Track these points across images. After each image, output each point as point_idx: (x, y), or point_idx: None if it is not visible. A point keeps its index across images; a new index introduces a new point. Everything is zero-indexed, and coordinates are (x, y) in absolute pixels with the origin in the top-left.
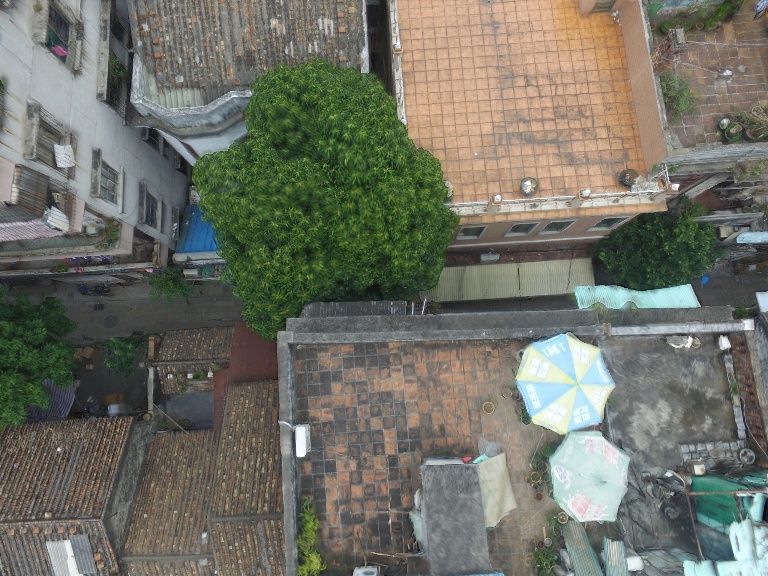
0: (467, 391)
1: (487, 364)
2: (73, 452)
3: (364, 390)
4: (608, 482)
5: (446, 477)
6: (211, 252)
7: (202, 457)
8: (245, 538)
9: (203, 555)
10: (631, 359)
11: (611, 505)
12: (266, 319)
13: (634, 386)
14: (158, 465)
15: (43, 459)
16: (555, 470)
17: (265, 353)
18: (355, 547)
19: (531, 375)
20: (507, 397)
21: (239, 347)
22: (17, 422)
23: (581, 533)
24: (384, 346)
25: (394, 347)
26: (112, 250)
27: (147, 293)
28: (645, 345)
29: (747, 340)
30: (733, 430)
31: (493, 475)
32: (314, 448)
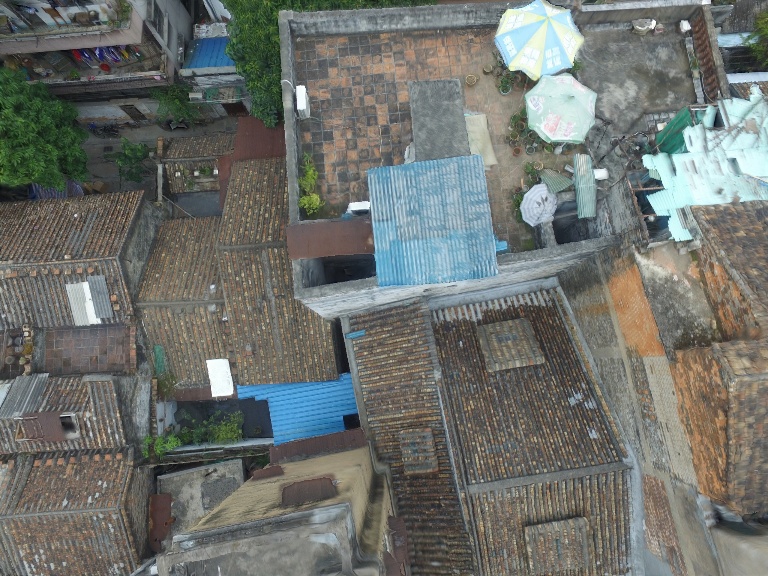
0: (452, 71)
1: (470, 49)
2: (89, 217)
3: (358, 73)
4: (576, 98)
5: (431, 89)
6: (215, 67)
7: (209, 235)
8: (251, 268)
9: (212, 300)
10: (601, 47)
11: (579, 123)
12: (268, 73)
13: (604, 69)
14: (168, 241)
15: (61, 222)
16: (529, 101)
17: (267, 141)
18: (351, 200)
19: (508, 29)
20: (488, 71)
21: (243, 136)
22: (38, 173)
23: (554, 171)
24: (376, 37)
25: (385, 38)
26: (123, 33)
27: (154, 135)
28: (614, 35)
29: (704, 13)
30: (693, 101)
31: (475, 128)
32: (313, 121)
